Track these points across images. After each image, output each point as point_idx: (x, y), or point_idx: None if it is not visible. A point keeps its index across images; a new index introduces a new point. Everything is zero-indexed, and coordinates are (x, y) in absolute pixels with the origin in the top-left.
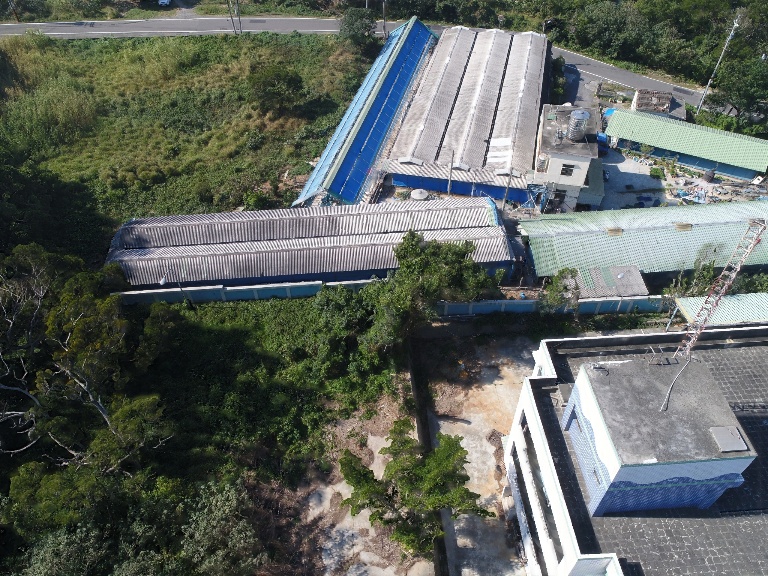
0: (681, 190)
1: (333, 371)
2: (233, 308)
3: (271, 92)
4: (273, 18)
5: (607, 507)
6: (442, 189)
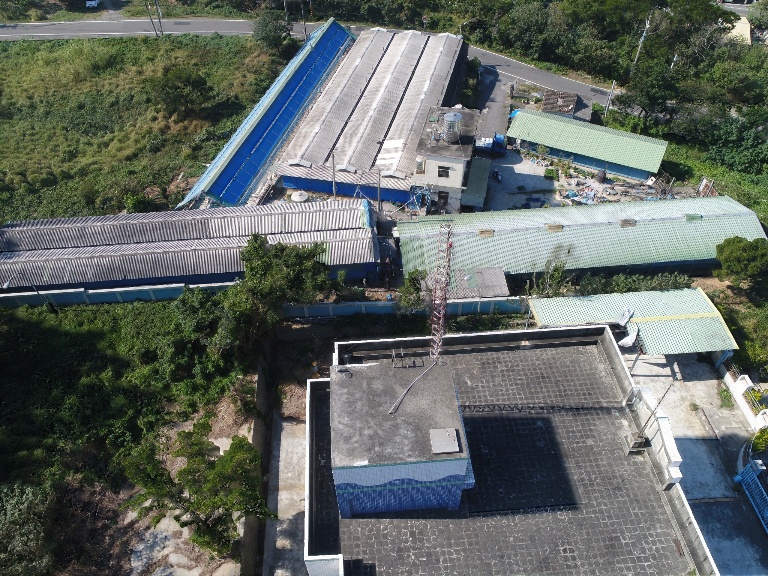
0: (572, 191)
1: (181, 373)
2: (94, 311)
3: (180, 94)
4: (198, 20)
5: (353, 509)
6: (331, 191)
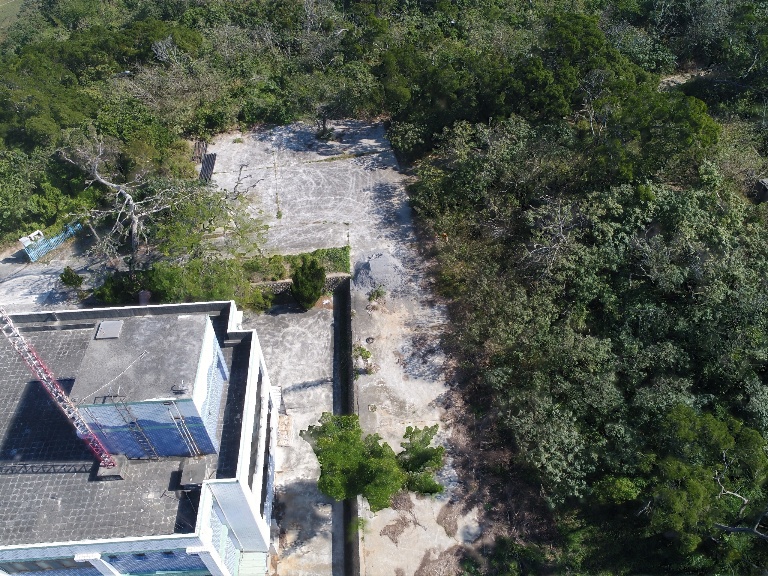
0: None
1: None
2: None
3: None
4: None
5: None
6: None
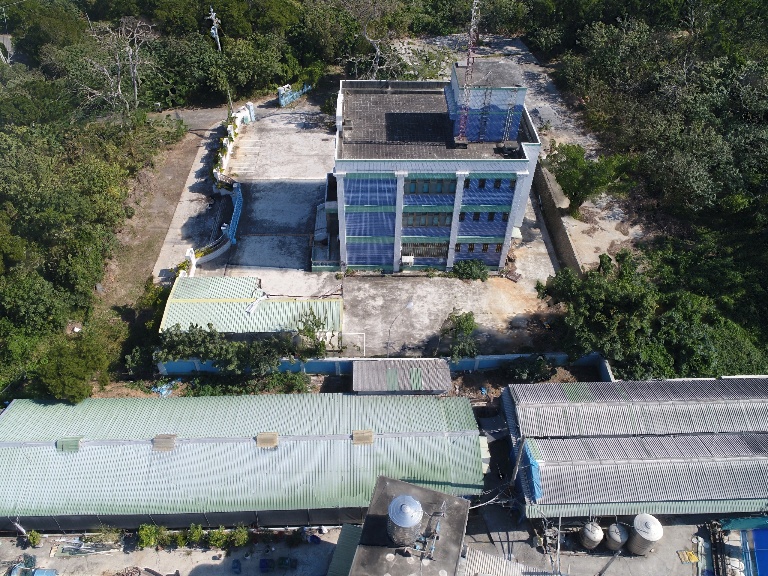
0: None
1: None
2: None
3: None
4: None
5: None
6: None
